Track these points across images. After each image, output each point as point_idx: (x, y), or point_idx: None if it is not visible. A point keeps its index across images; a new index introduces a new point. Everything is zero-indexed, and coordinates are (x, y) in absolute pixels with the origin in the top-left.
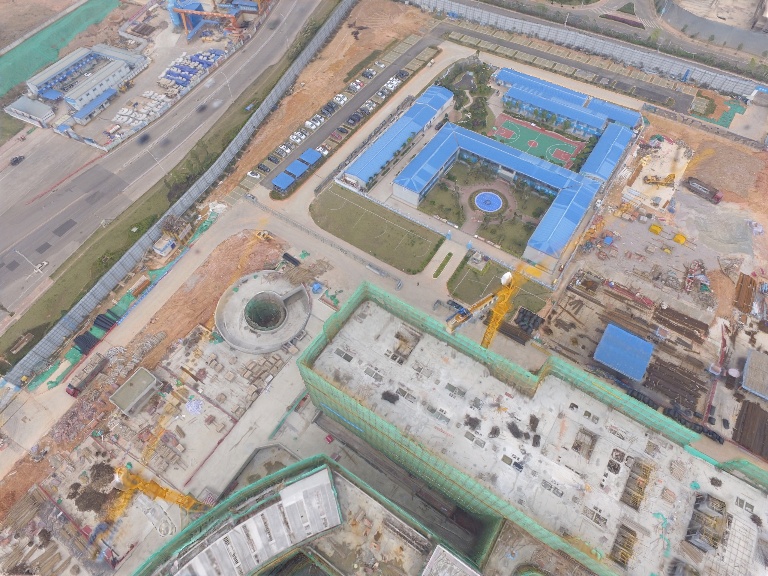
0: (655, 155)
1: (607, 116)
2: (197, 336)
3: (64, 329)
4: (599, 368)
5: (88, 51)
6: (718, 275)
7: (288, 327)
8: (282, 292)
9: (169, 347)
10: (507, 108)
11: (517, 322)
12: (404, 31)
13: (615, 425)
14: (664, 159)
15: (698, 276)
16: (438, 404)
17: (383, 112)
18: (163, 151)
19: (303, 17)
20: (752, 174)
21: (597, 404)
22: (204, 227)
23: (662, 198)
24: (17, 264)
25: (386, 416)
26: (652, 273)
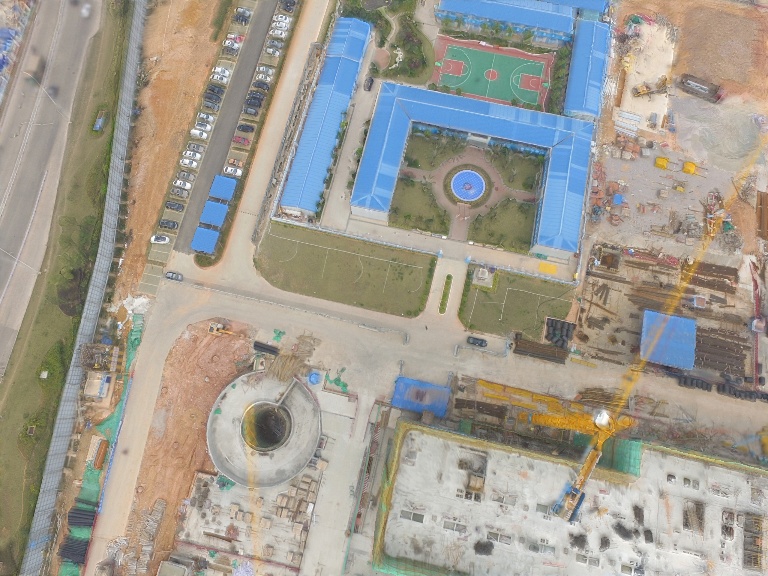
0: (635, 48)
1: (571, 9)
2: (202, 489)
3: (36, 546)
4: (647, 366)
5: None
6: (738, 205)
7: (299, 429)
8: (275, 396)
9: (177, 515)
10: (442, 25)
11: (549, 339)
12: None
13: (716, 484)
14: (646, 51)
15: (718, 212)
16: (537, 535)
17: (286, 80)
18: (13, 238)
19: None
20: (745, 45)
21: (693, 466)
22: (135, 342)
23: (657, 113)
24: None
25: (488, 573)
26: (671, 225)
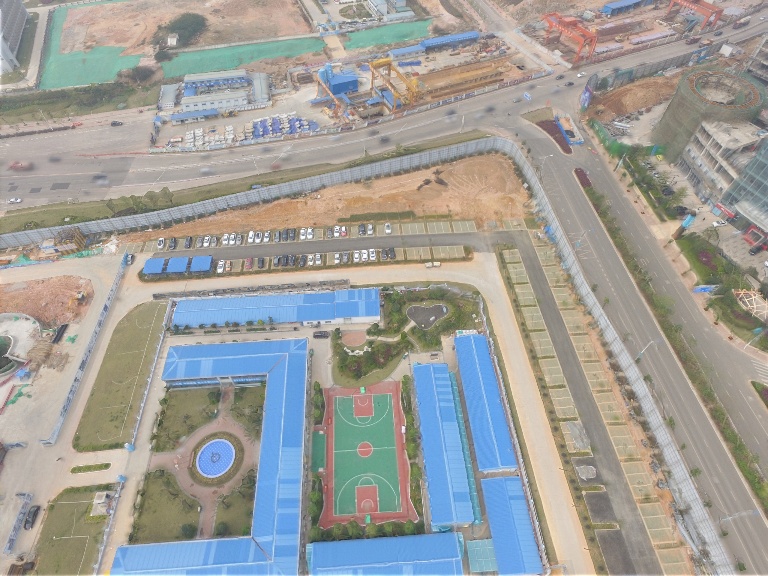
0: None
1: (470, 519)
2: None
3: None
4: None
5: (244, 74)
6: None
7: None
8: (17, 352)
9: None
10: None
11: None
12: (471, 212)
13: None
14: None
15: None
16: None
17: (315, 275)
18: (169, 177)
19: (417, 138)
20: None
21: None
22: (80, 254)
23: None
24: (15, 189)
25: None
26: None
